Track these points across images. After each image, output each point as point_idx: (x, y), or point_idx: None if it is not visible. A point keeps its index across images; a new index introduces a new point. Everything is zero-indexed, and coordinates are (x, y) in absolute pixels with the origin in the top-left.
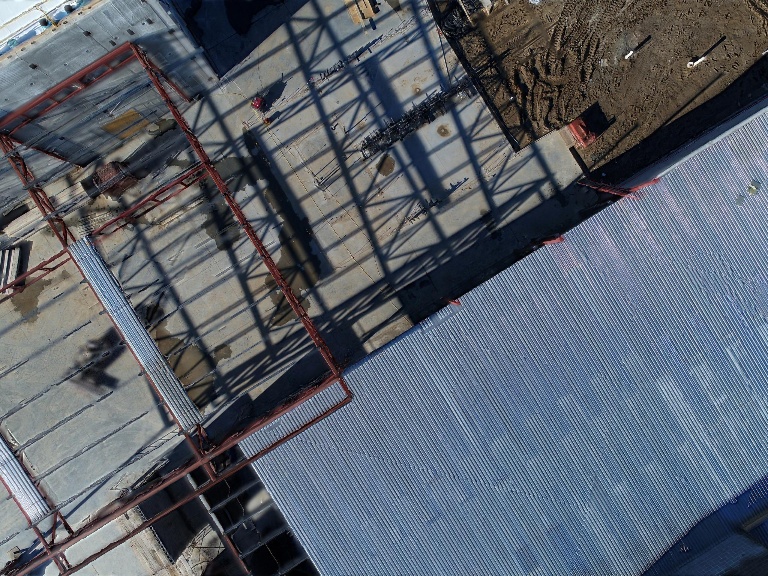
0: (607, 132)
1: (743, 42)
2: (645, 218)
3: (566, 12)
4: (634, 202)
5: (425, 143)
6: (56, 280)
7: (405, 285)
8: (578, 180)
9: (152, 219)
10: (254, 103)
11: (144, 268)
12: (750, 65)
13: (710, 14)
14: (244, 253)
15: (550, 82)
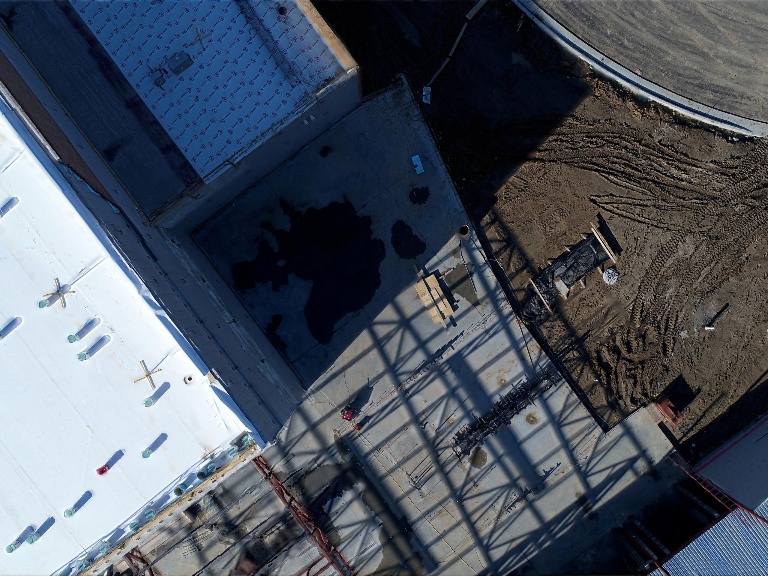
0: (693, 403)
1: None
2: (754, 531)
3: (643, 289)
4: (742, 516)
5: (515, 433)
6: None
7: (507, 573)
8: (669, 454)
9: (253, 533)
10: (345, 416)
11: None
12: None
13: None
14: (346, 557)
15: (632, 358)
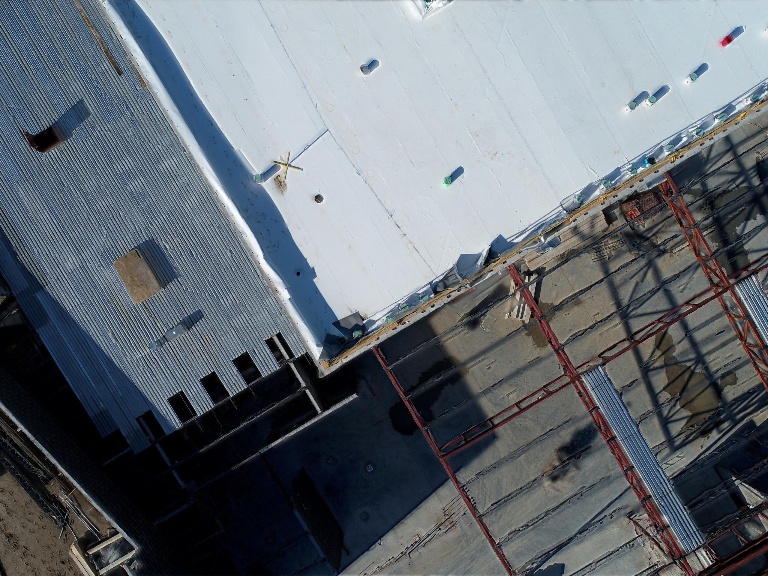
0: None
1: None
2: None
3: None
4: None
5: None
6: (567, 306)
7: None
8: None
9: (664, 247)
10: None
11: (654, 295)
12: None
13: None
14: None
15: None
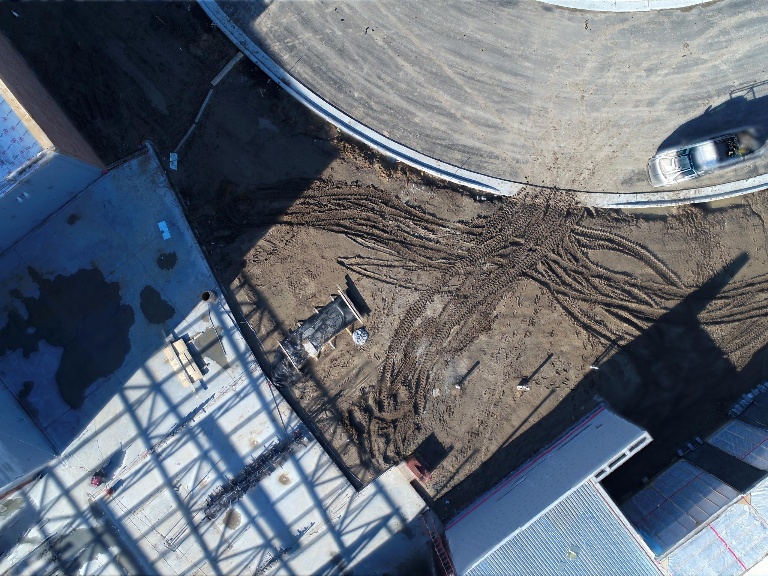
0: (446, 460)
1: (570, 357)
2: None
3: (393, 348)
4: None
5: (268, 493)
6: None
7: None
8: (422, 512)
9: None
10: (94, 482)
11: None
12: (580, 379)
13: (535, 334)
14: None
15: (385, 417)
